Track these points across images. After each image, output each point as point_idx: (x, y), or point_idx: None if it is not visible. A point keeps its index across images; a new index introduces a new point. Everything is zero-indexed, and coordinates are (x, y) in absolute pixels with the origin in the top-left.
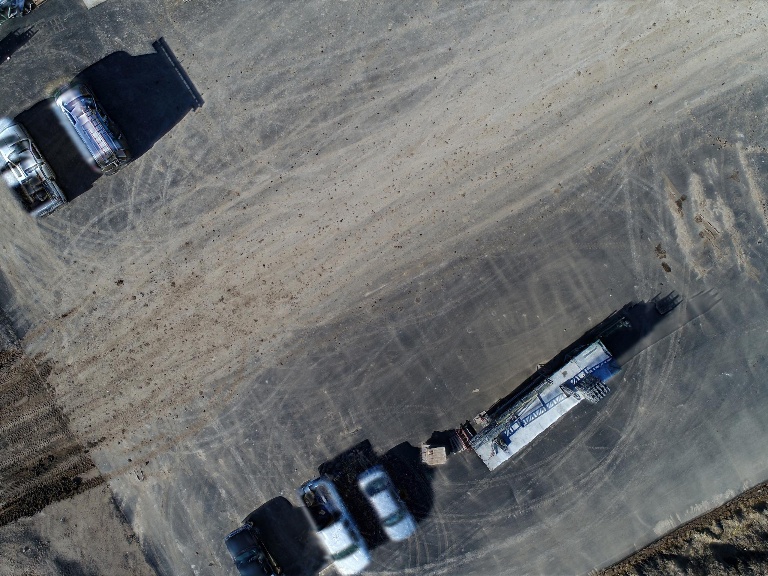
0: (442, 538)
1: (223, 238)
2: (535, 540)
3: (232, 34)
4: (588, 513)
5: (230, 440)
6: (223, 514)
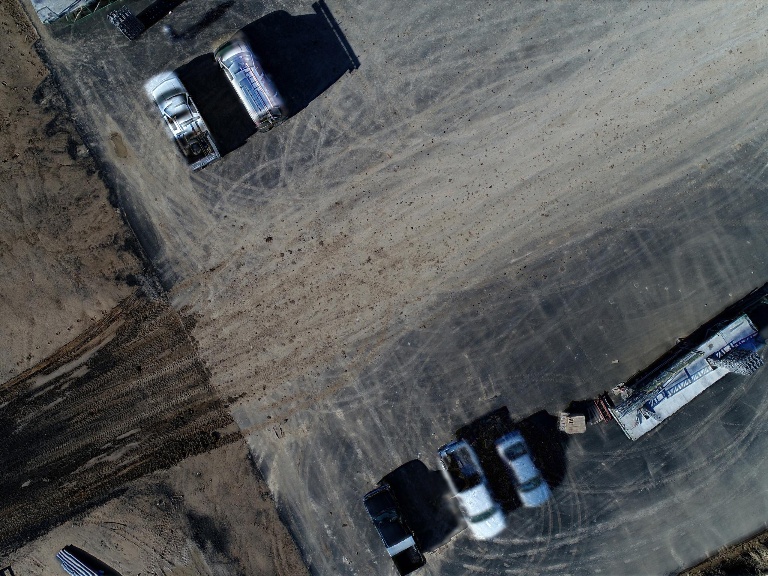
0: (575, 508)
1: (373, 199)
2: (667, 514)
3: None
4: (720, 489)
5: (370, 401)
6: (359, 475)
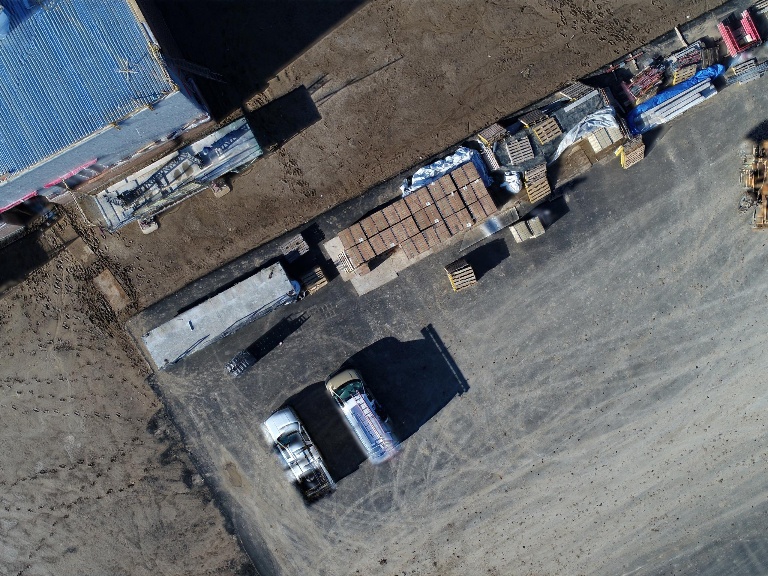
0: None
1: (484, 520)
2: None
3: (499, 321)
4: None
5: None
6: None
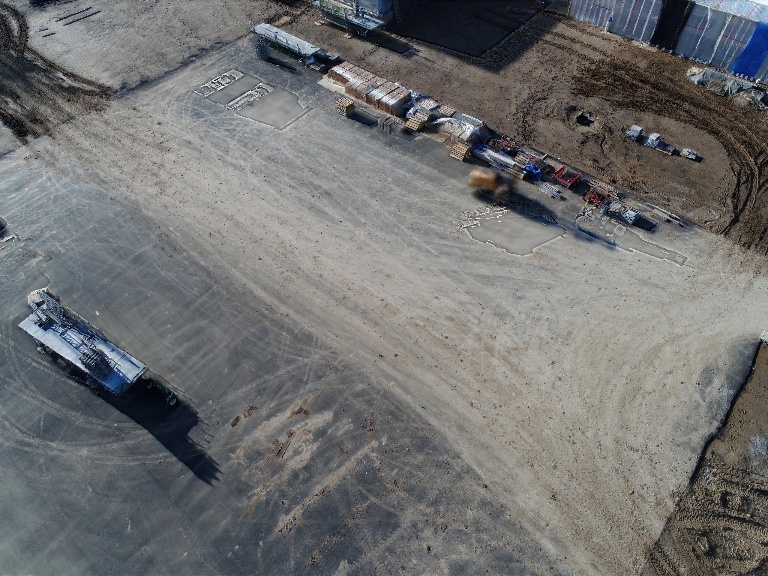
0: None
1: (197, 155)
2: None
3: (327, 131)
4: None
5: (53, 190)
6: None
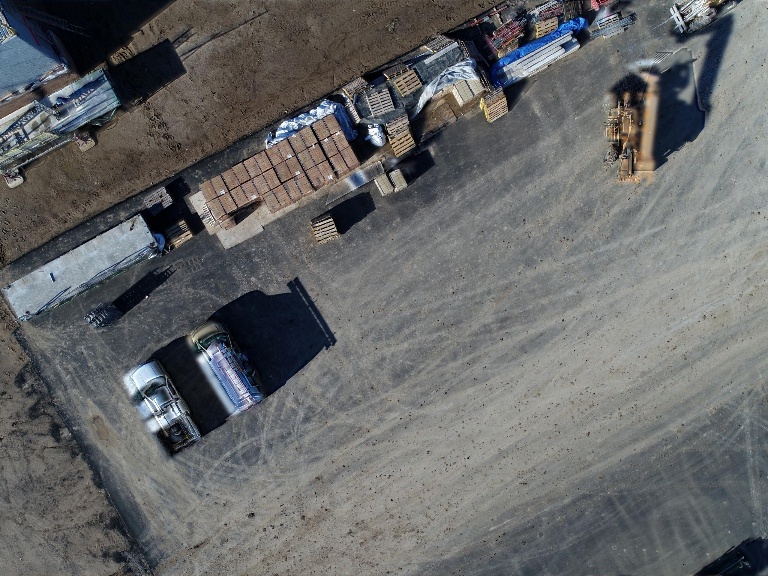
0: None
1: (352, 473)
2: None
3: (365, 275)
4: None
5: None
6: None
